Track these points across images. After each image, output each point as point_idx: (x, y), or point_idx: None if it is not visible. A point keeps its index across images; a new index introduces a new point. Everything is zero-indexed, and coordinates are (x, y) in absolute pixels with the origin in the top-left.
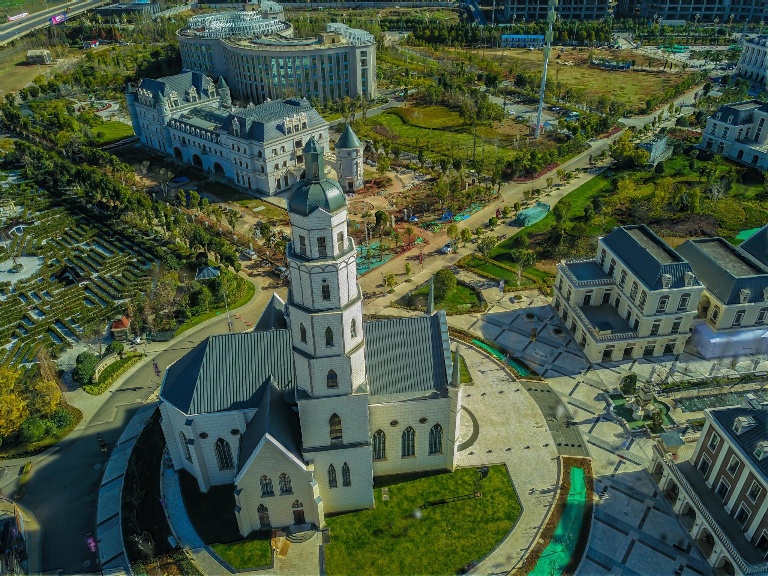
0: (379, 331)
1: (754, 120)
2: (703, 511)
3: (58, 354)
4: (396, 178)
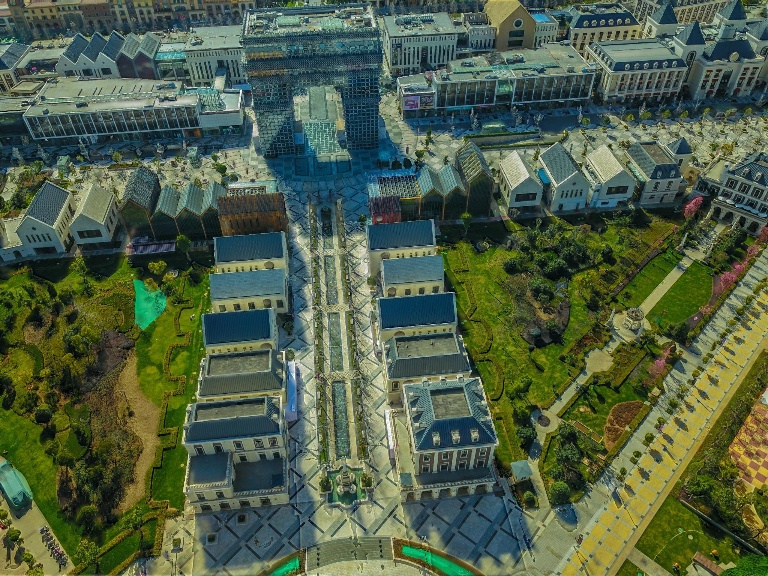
0: None
1: None
2: (456, 484)
3: None
4: None
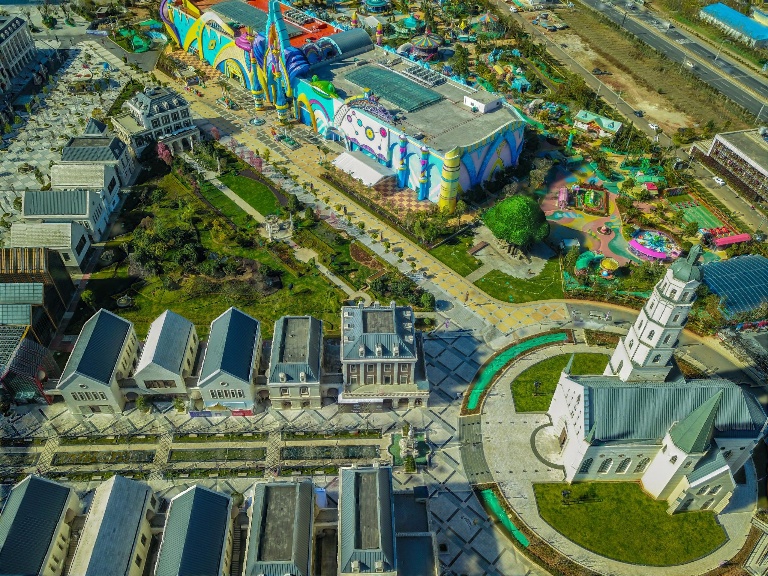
0: None
1: None
2: None
3: None
4: None
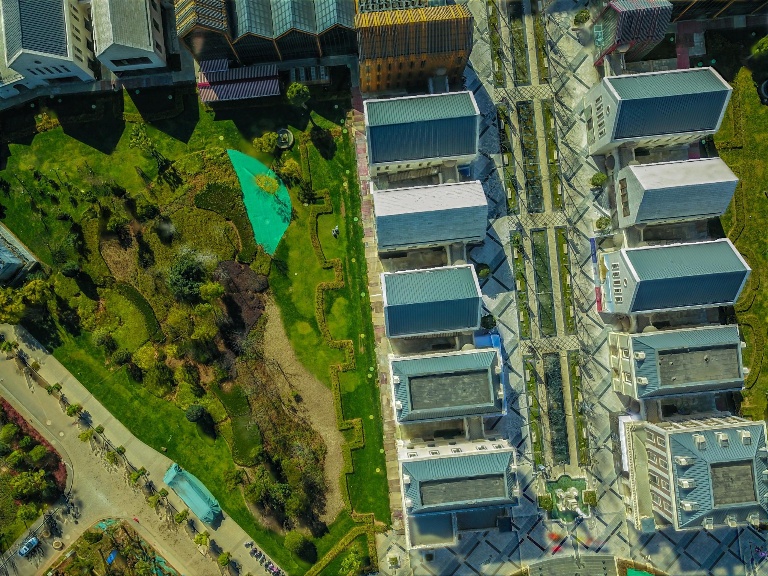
0: None
1: None
2: None
3: None
4: None
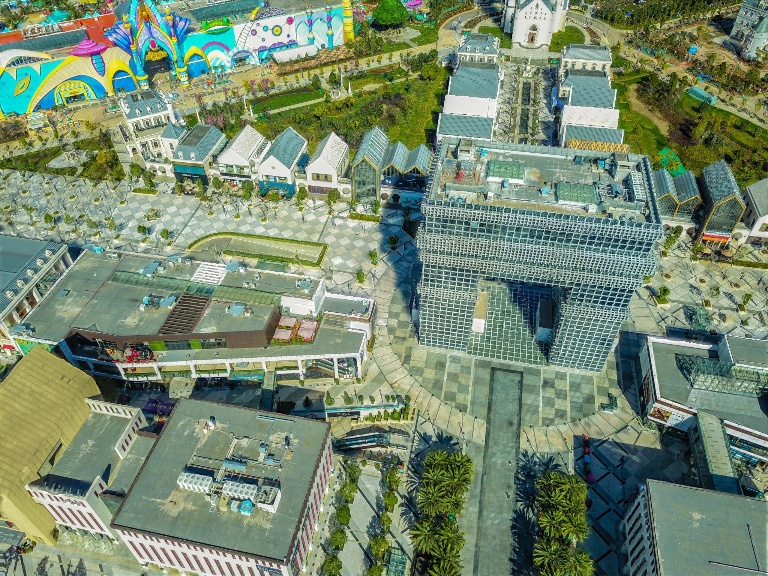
0: None
1: None
2: None
3: (587, 3)
4: (766, 71)
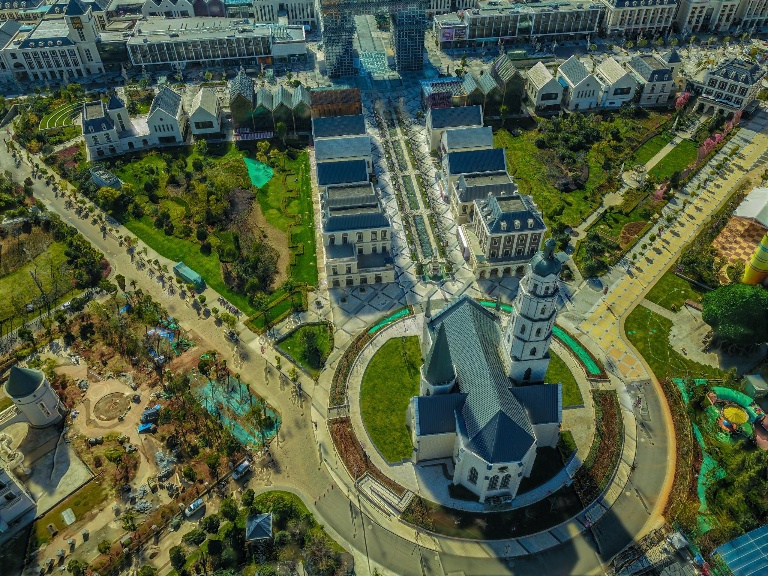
0: (478, 327)
1: (112, 118)
2: (516, 262)
3: None
4: None
